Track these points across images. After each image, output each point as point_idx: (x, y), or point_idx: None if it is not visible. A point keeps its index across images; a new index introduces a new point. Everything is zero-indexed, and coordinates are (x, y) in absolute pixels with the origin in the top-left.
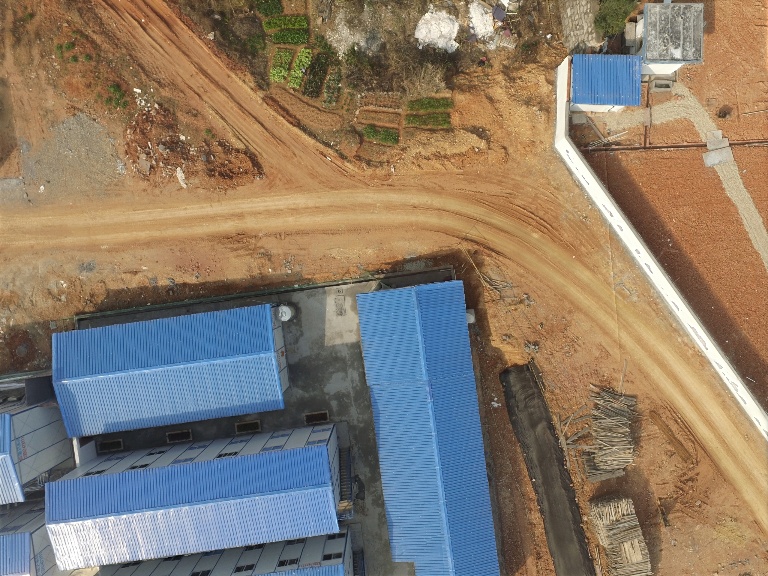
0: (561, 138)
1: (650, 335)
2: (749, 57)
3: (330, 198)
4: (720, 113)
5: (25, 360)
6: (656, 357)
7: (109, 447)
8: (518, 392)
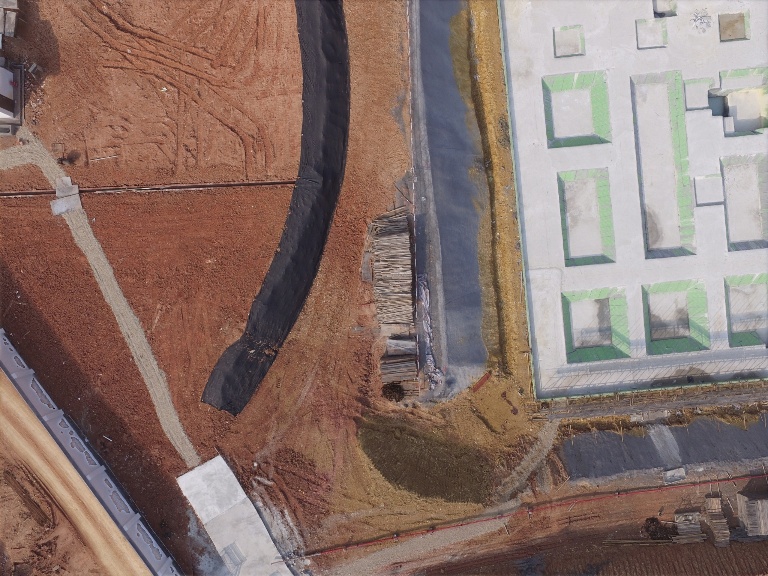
0: None
1: (2, 392)
2: (97, 100)
3: None
4: (57, 159)
5: None
6: (9, 415)
7: None
8: None
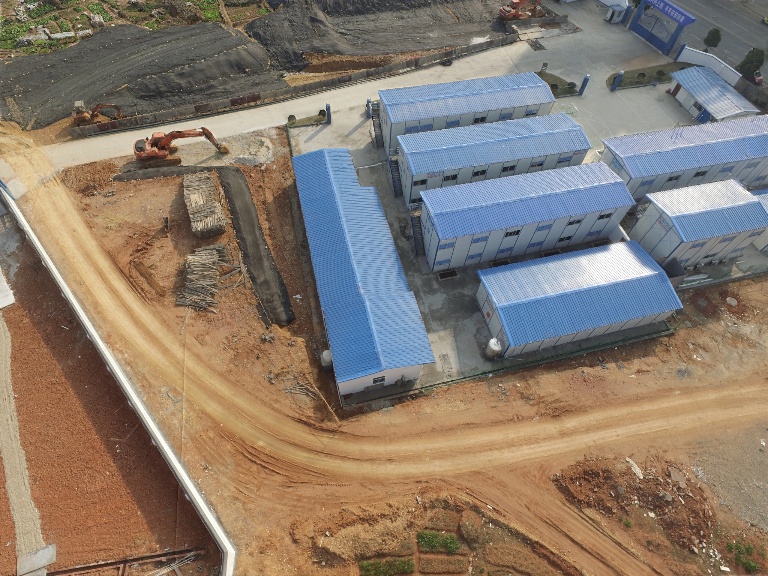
0: (230, 554)
1: (154, 357)
2: None
3: (479, 461)
4: None
5: (696, 296)
6: (152, 339)
7: (602, 243)
8: (279, 307)
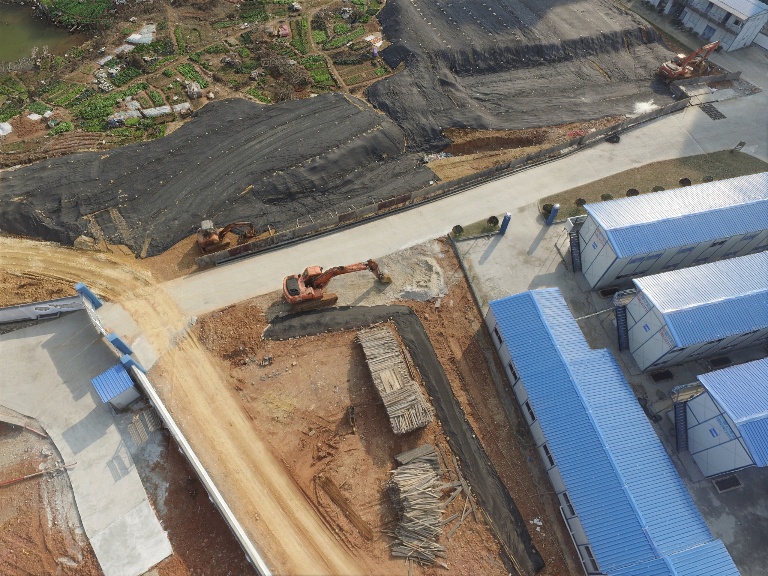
0: None
1: None
2: None
3: None
4: None
5: None
6: None
7: None
8: (517, 542)
